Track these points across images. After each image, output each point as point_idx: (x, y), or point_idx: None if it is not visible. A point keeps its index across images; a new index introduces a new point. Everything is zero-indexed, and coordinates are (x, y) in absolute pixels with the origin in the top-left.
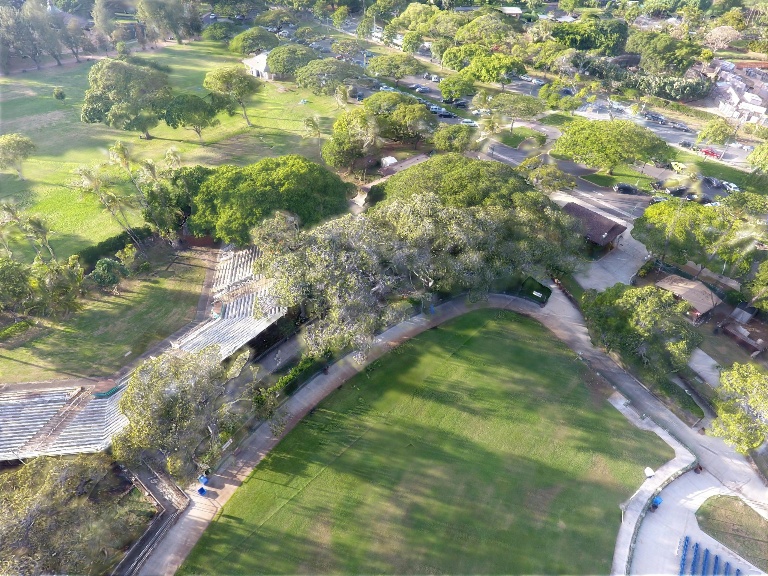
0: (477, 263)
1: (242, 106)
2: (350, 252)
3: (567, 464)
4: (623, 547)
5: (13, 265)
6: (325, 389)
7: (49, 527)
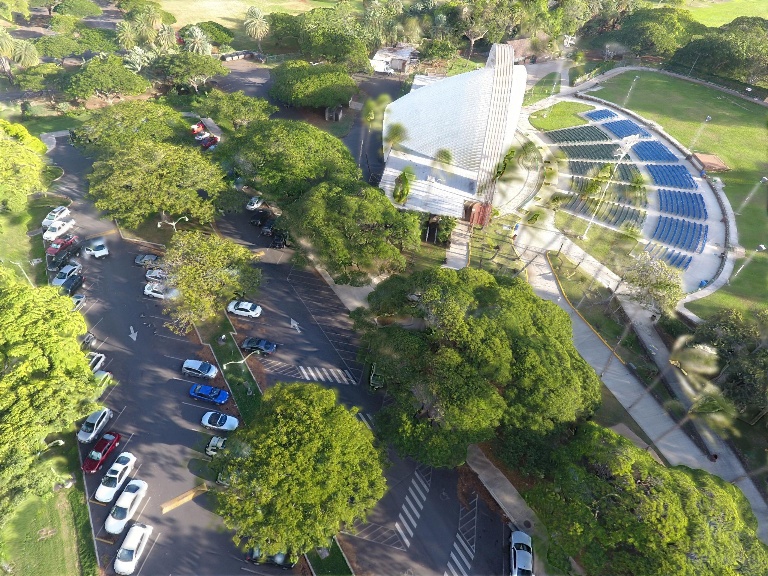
0: None
1: None
2: None
3: None
4: (728, 270)
5: None
6: None
7: None
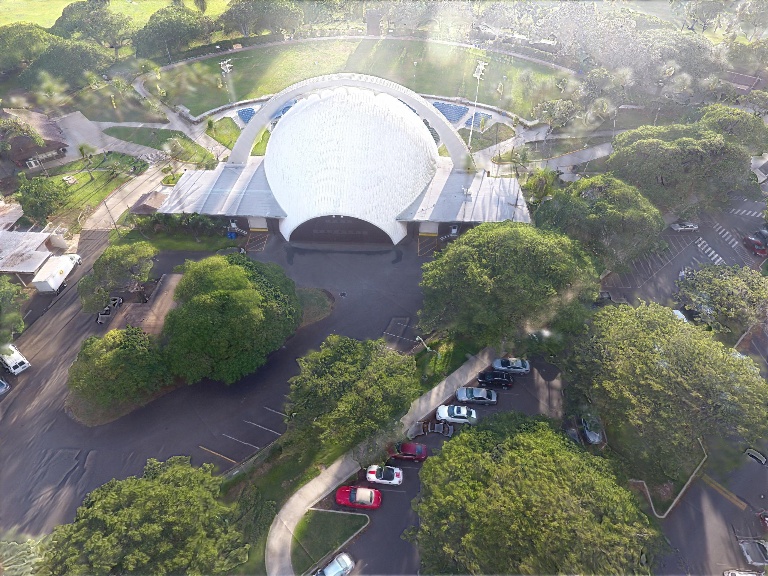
0: (590, 36)
1: (755, 30)
2: (568, 8)
3: (512, 98)
4: None
5: (547, 10)
6: (522, 57)
7: (456, 2)
